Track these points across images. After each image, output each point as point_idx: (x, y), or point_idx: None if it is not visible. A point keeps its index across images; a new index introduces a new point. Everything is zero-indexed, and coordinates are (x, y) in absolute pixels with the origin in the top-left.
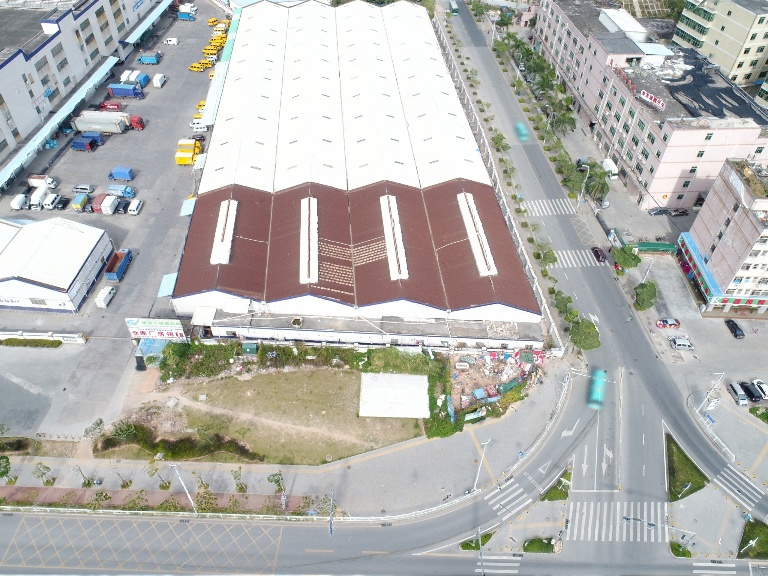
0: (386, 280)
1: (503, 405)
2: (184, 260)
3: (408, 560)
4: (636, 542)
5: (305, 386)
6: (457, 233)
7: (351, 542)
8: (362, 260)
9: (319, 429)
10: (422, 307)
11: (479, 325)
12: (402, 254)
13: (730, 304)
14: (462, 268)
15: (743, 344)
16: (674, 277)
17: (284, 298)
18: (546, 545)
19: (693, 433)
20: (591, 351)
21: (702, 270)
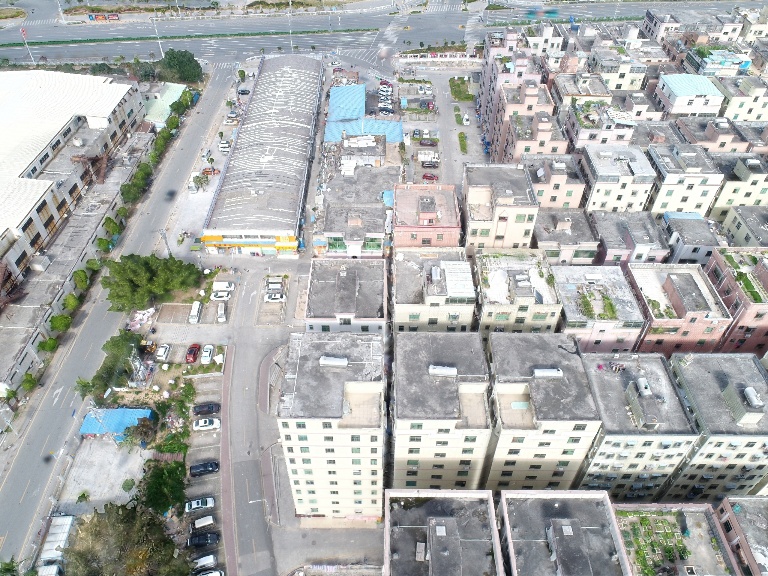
0: None
1: None
2: None
3: (371, 17)
4: None
5: None
6: None
7: (350, 16)
8: None
9: None
10: None
11: None
12: None
13: None
14: None
15: None
16: None
17: None
18: None
19: None
20: None
21: None
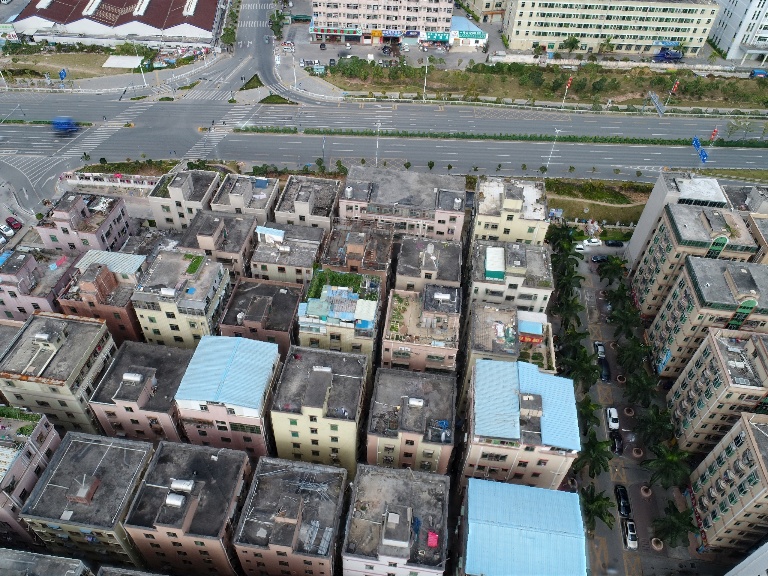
0: (131, 16)
1: (178, 65)
2: (24, 11)
3: (104, 102)
4: (214, 100)
5: (77, 57)
6: (183, 4)
7: (79, 98)
8: (124, 12)
9: (79, 69)
10: (147, 26)
11: (179, 38)
12: (144, 6)
13: (320, 33)
14: (177, 15)
15: (323, 52)
16: (308, 31)
17: (72, 21)
18: (170, 98)
19: (270, 75)
20: (239, 52)
21: (311, 19)
